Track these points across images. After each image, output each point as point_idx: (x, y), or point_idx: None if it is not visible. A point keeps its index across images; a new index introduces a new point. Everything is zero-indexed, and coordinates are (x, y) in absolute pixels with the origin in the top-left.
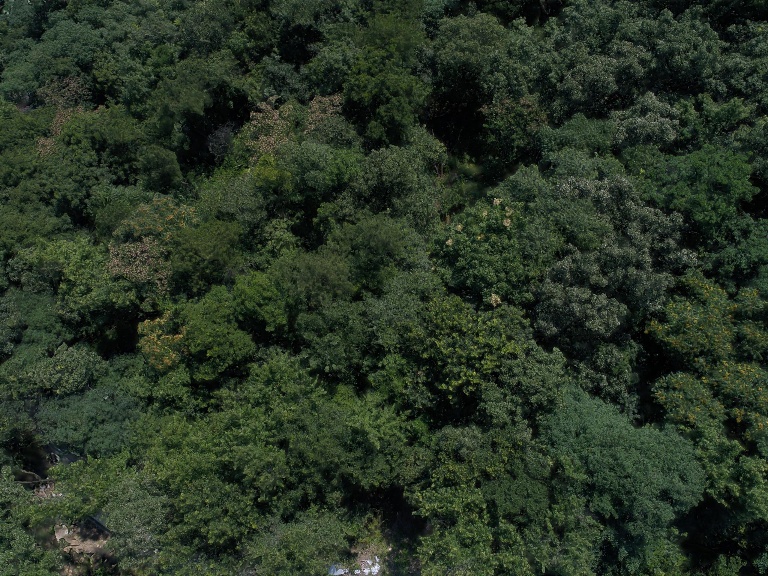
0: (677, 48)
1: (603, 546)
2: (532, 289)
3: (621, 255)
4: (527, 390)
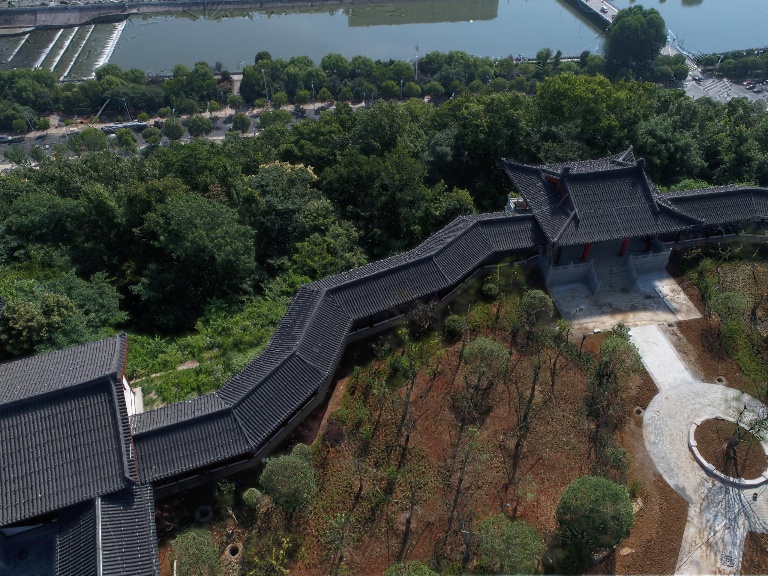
0: (213, 143)
1: (9, 252)
2: (55, 183)
3: (106, 162)
4: (4, 188)
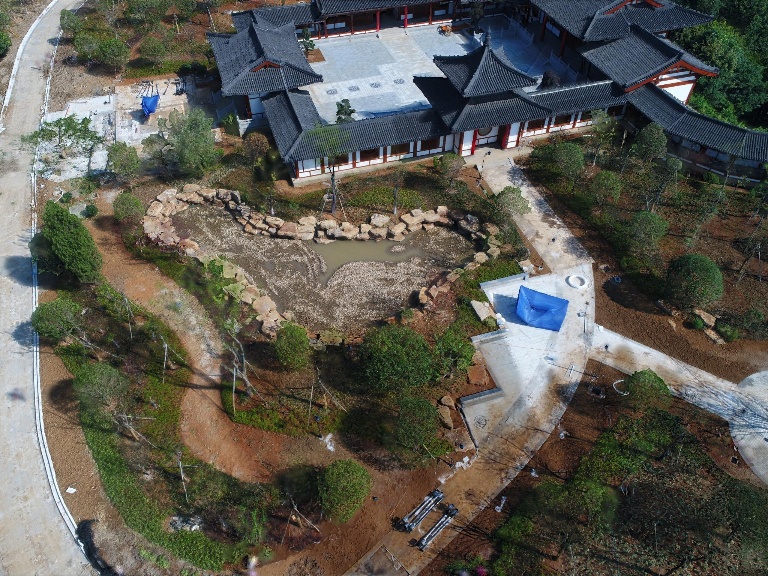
0: None
1: None
2: None
3: None
4: None
